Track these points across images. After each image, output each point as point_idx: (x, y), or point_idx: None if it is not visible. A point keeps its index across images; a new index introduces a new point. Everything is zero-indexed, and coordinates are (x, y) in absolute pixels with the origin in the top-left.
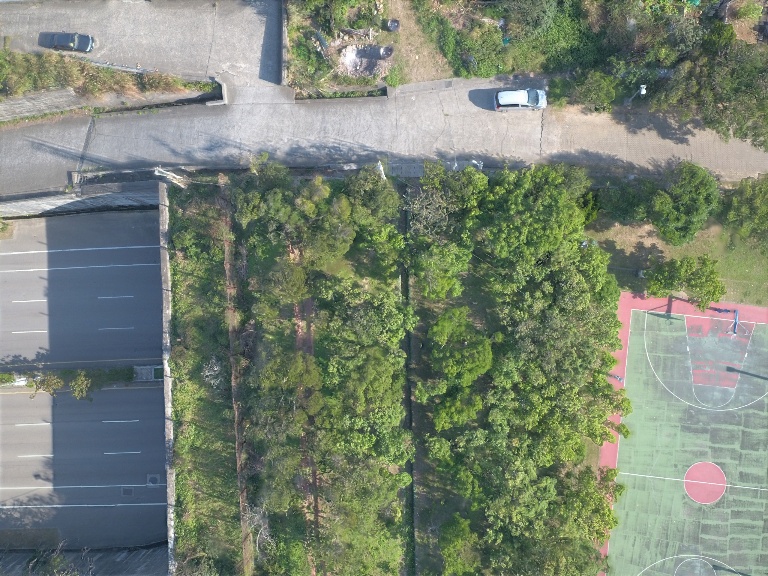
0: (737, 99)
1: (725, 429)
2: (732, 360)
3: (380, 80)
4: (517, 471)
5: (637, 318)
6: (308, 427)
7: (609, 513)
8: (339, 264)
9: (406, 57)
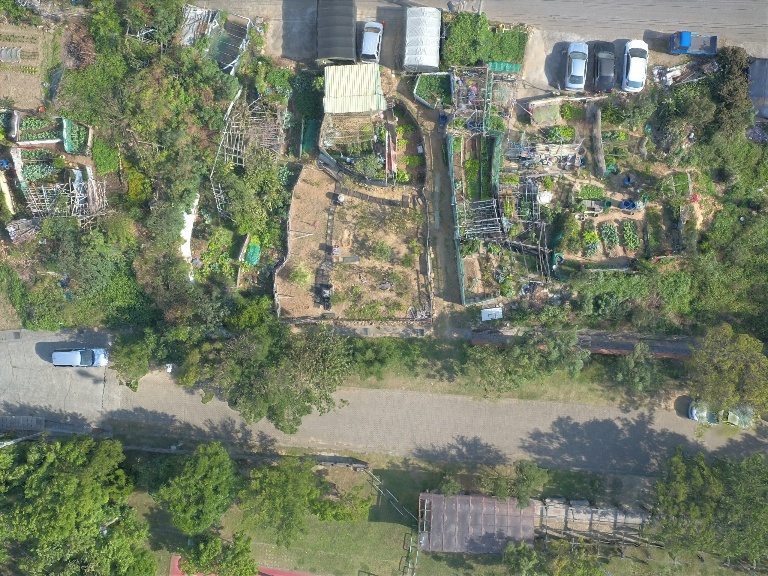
0: (252, 386)
1: None
2: None
3: None
4: None
5: None
6: None
7: None
8: None
9: None
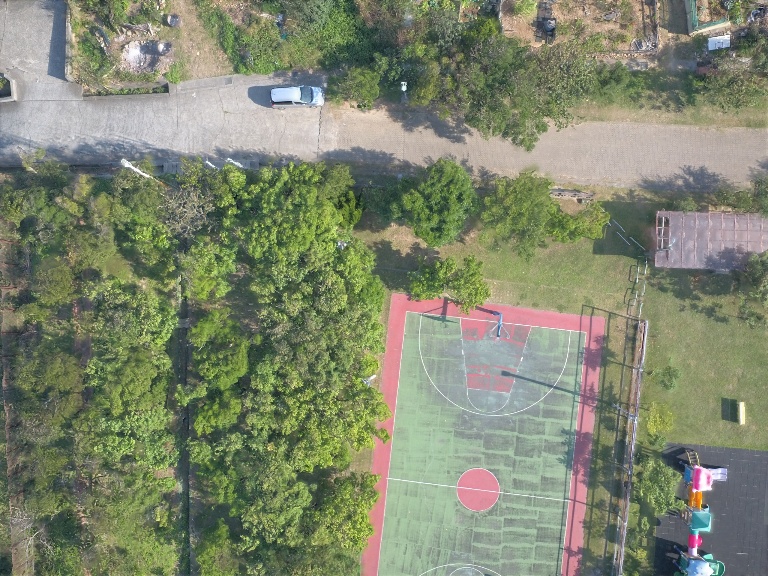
0: (494, 96)
1: (499, 435)
2: (507, 364)
3: (161, 76)
4: (265, 477)
5: (412, 320)
6: (67, 430)
7: (362, 520)
8: (118, 264)
9: (187, 53)
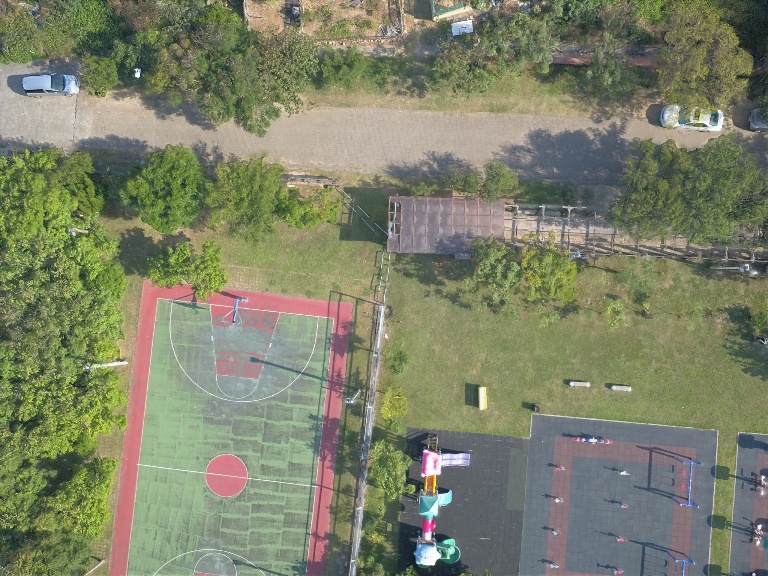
0: None
1: (248, 421)
2: (256, 350)
3: None
4: None
5: (163, 307)
6: None
7: (92, 505)
8: None
9: None
